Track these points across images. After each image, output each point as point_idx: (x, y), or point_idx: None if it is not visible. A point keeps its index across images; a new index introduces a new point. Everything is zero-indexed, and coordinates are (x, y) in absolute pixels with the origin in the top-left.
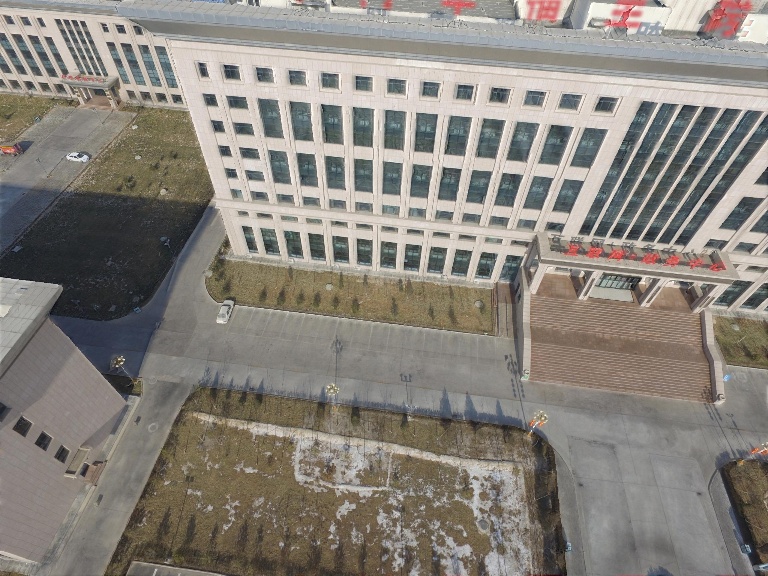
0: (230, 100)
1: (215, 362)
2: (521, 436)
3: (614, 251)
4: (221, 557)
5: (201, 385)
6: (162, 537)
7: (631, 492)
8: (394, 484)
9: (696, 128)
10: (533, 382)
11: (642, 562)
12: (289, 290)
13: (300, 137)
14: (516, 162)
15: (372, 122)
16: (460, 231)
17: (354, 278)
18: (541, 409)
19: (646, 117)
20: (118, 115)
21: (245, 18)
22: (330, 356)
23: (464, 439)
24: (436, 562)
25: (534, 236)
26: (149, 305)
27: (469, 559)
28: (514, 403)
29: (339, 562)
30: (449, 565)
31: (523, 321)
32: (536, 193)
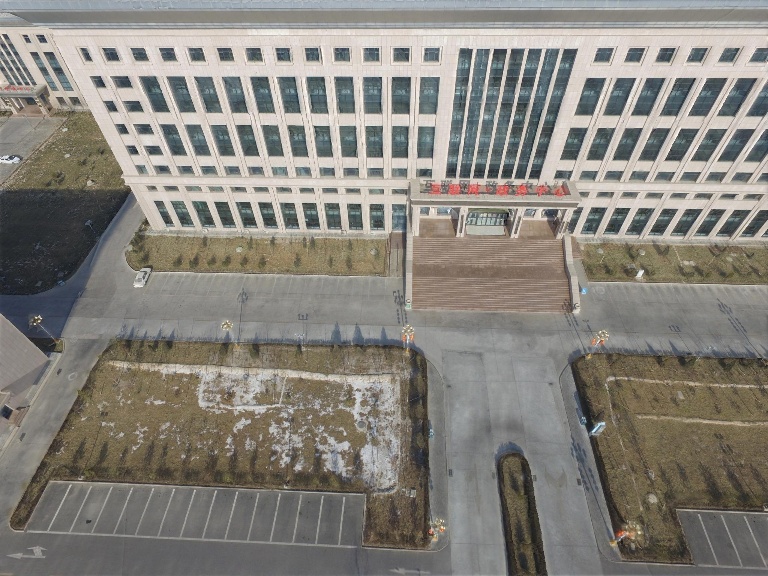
0: (115, 80)
1: (131, 319)
2: (401, 353)
3: (470, 186)
4: (129, 471)
5: (118, 339)
6: (77, 461)
7: (492, 388)
8: (286, 401)
9: (511, 69)
10: (416, 310)
11: (495, 440)
12: (202, 255)
13: (184, 109)
14: (373, 115)
15: (241, 89)
16: (344, 185)
17: (262, 240)
18: (421, 331)
19: (468, 63)
20: (49, 121)
21: (105, 2)
22: (236, 305)
23: (350, 360)
24: (318, 457)
25: (409, 183)
26: (73, 278)
27: (347, 452)
28: (397, 328)
29: (233, 465)
30: (329, 458)
31: (406, 259)
32: (399, 142)
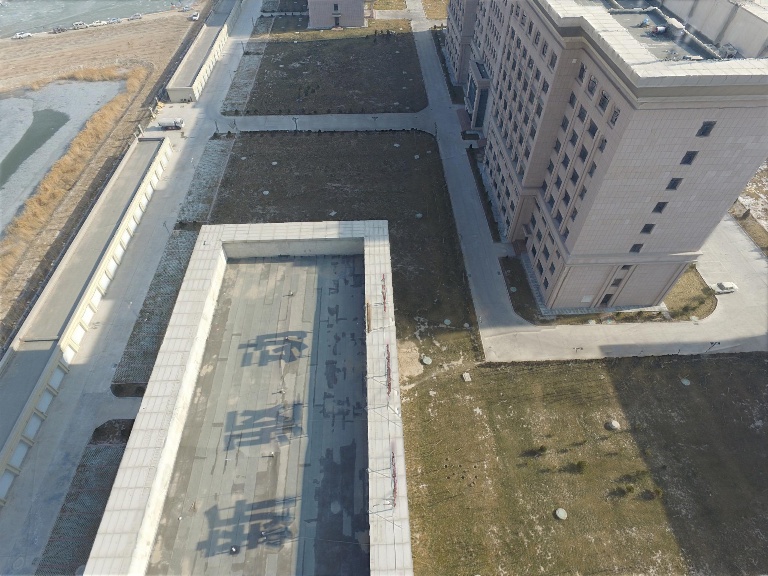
0: None
1: (765, 282)
2: None
3: None
4: None
5: None
6: None
7: None
8: None
9: None
10: None
11: None
12: None
13: None
14: None
15: None
16: None
17: None
18: None
19: None
20: None
21: None
22: None
23: None
24: (765, 171)
25: None
26: None
27: None
28: None
29: None
30: (762, 167)
31: None
32: None
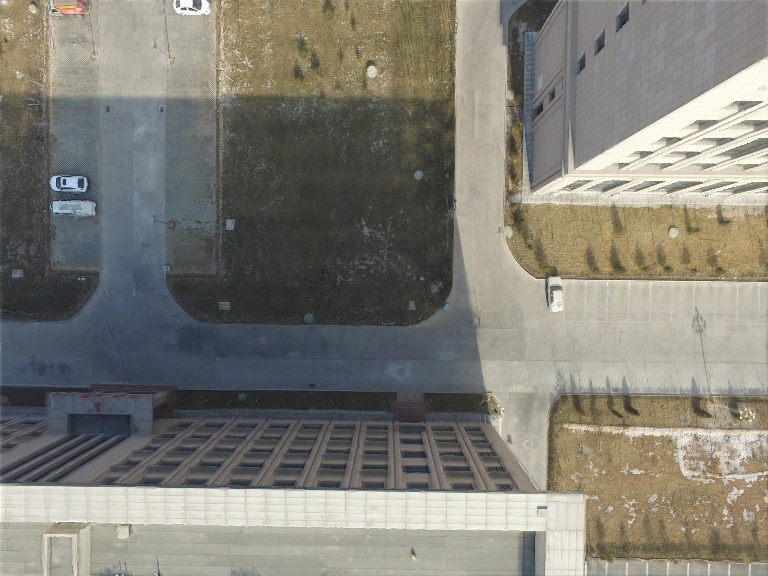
0: None
1: (564, 363)
2: None
3: None
4: (636, 546)
5: (559, 392)
6: None
7: None
8: None
9: None
10: None
11: None
12: (622, 245)
13: None
14: None
15: None
16: None
17: (704, 212)
18: None
19: None
20: None
21: None
22: (694, 337)
23: None
24: None
25: None
26: (453, 294)
27: None
28: None
29: (736, 537)
30: None
31: None
32: None
